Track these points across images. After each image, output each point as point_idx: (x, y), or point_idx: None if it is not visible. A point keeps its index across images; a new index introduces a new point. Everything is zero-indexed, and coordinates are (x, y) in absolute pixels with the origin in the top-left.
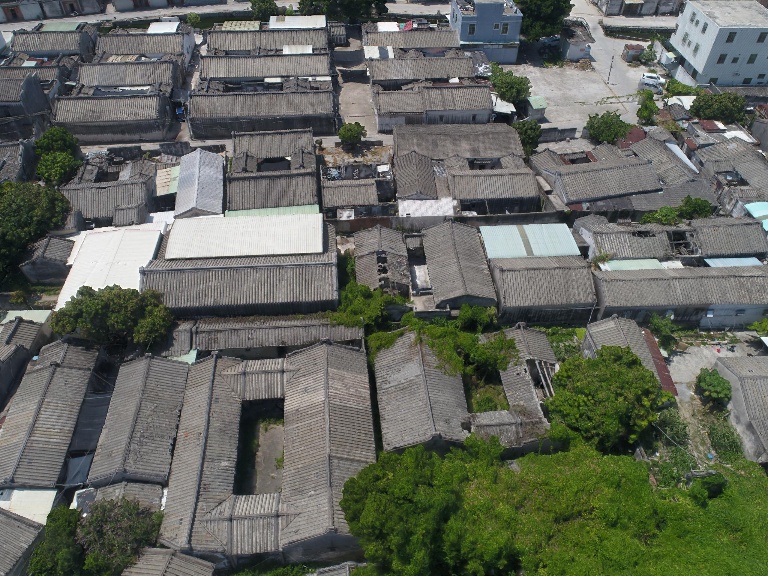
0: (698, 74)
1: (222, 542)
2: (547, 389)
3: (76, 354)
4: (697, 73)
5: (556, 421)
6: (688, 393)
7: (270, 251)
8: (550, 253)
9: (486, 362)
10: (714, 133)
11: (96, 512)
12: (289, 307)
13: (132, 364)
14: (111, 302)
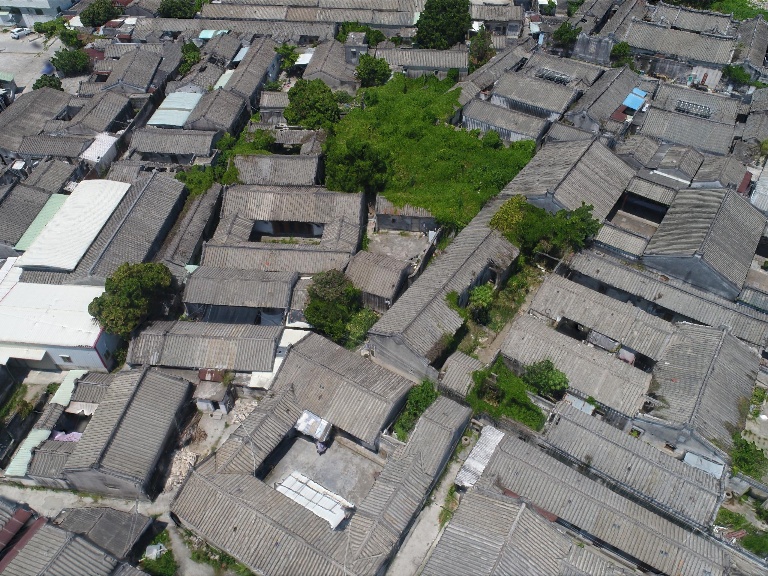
0: (44, 12)
1: (349, 246)
2: (297, 126)
3: (155, 329)
4: (42, 11)
5: (320, 125)
6: None
7: (111, 209)
8: (194, 103)
9: (267, 144)
10: (122, 26)
11: (317, 290)
12: (174, 212)
13: (188, 291)
14: (133, 274)
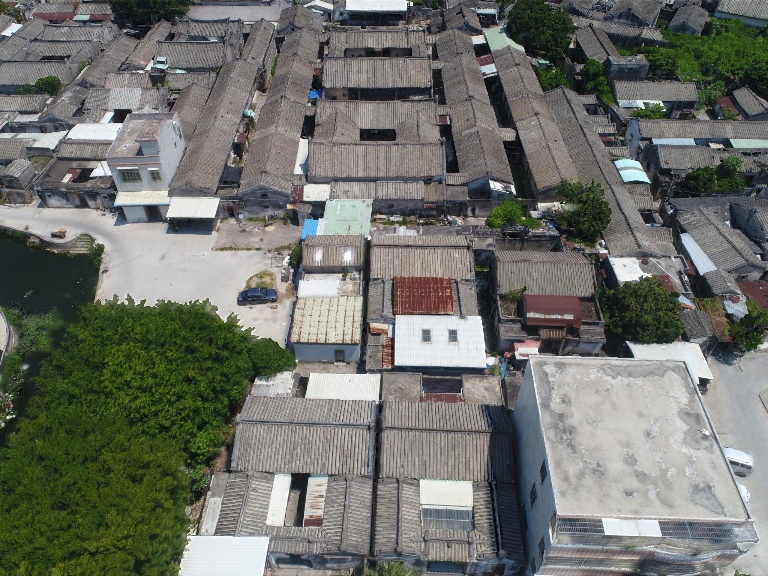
0: None
1: None
2: None
3: None
4: None
5: None
6: (700, 117)
7: None
8: None
9: None
10: None
11: None
12: None
13: None
14: None
